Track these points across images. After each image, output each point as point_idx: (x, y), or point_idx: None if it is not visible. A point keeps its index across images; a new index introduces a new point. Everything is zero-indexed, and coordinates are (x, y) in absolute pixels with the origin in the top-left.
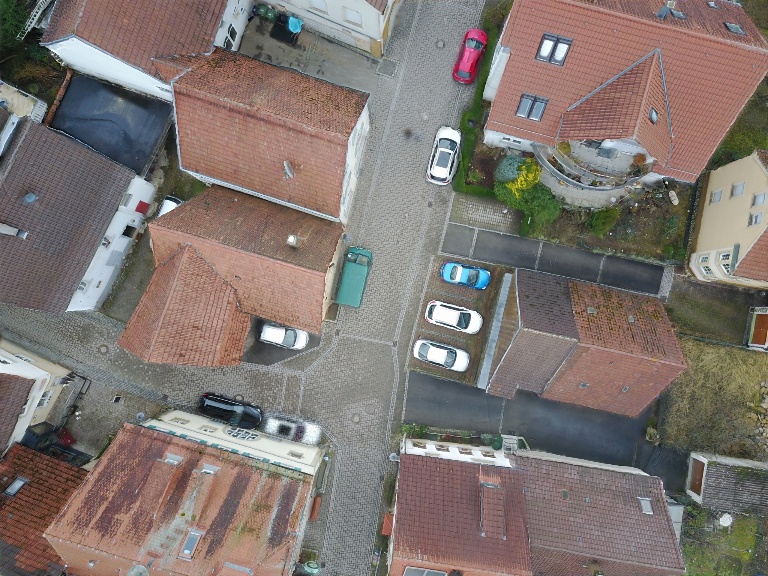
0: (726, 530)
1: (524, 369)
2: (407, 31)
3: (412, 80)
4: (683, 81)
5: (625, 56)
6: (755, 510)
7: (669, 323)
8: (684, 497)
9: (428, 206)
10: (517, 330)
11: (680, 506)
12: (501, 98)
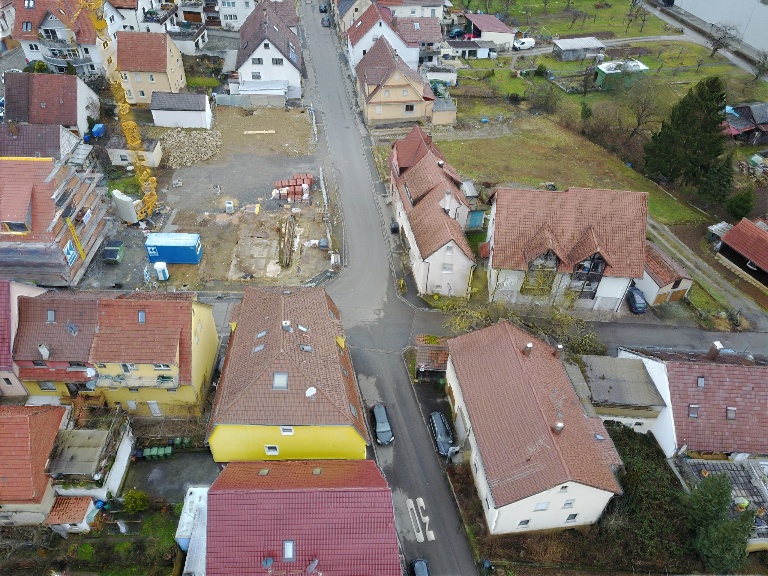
0: (134, 176)
1: (16, 104)
2: (11, 55)
3: (8, 64)
4: (75, 6)
5: (53, 1)
6: (135, 148)
7: (91, 89)
8: (111, 165)
9: (1, 90)
10: (4, 74)
11: (90, 145)
12: (16, 25)
